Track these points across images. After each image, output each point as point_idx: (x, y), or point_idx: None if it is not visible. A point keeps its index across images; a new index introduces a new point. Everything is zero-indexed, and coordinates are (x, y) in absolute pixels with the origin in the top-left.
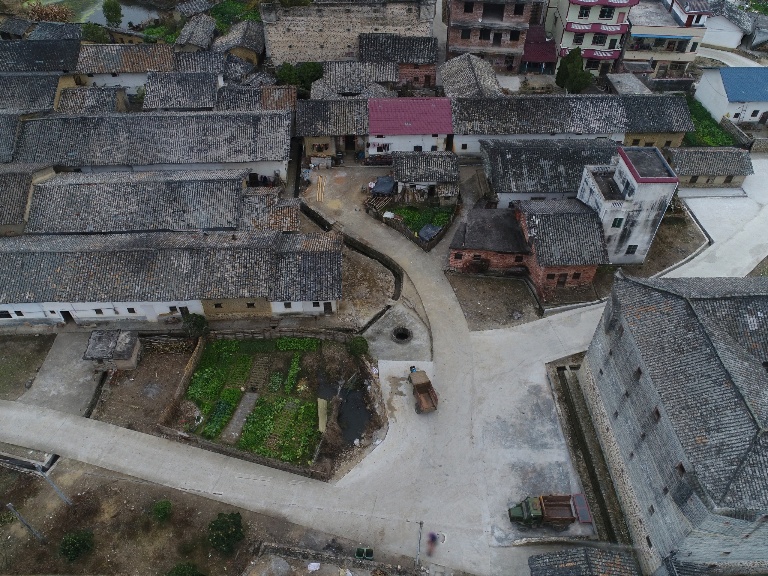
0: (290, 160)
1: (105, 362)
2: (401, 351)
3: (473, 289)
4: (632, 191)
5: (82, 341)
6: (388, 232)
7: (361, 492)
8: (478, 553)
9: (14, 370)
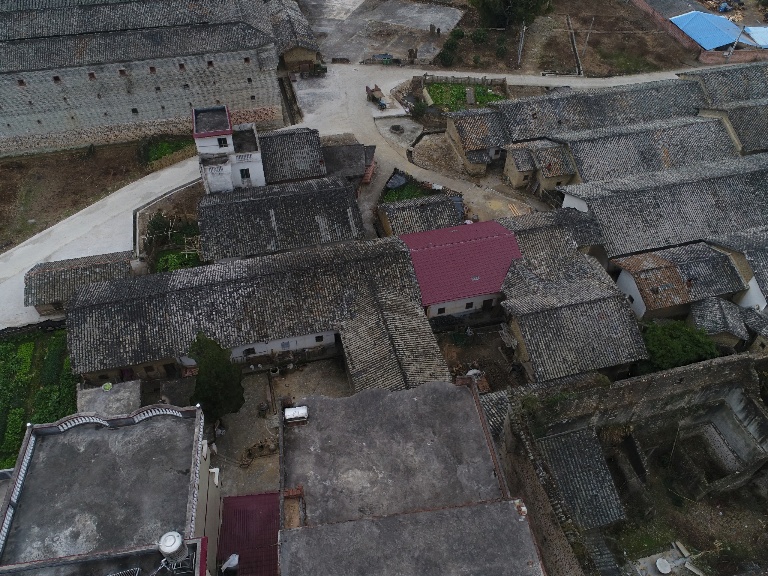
0: None
1: None
2: (395, 124)
3: None
4: None
5: None
6: None
7: None
8: None
9: None
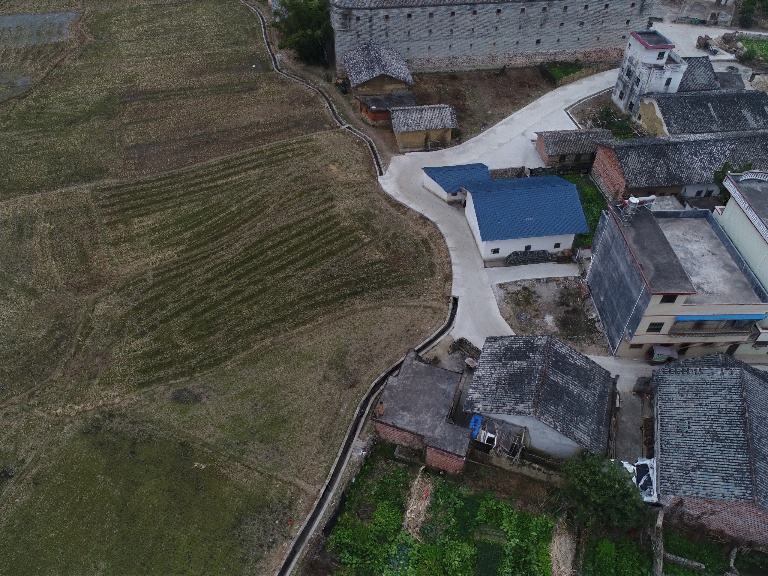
0: None
1: None
2: None
3: None
4: None
5: None
6: None
7: None
8: None
9: None
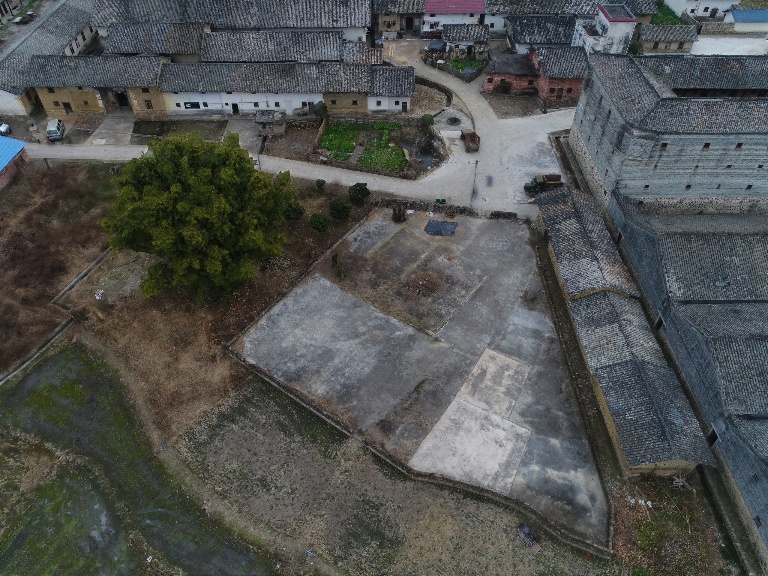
0: (366, 36)
1: (267, 128)
2: (454, 129)
3: (500, 101)
4: (607, 30)
5: (246, 123)
6: (440, 73)
7: (435, 184)
8: (506, 205)
9: (207, 135)
